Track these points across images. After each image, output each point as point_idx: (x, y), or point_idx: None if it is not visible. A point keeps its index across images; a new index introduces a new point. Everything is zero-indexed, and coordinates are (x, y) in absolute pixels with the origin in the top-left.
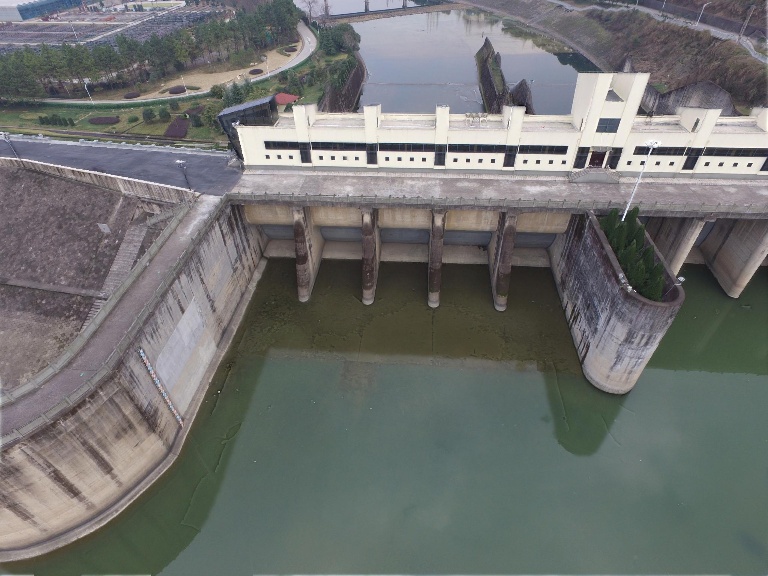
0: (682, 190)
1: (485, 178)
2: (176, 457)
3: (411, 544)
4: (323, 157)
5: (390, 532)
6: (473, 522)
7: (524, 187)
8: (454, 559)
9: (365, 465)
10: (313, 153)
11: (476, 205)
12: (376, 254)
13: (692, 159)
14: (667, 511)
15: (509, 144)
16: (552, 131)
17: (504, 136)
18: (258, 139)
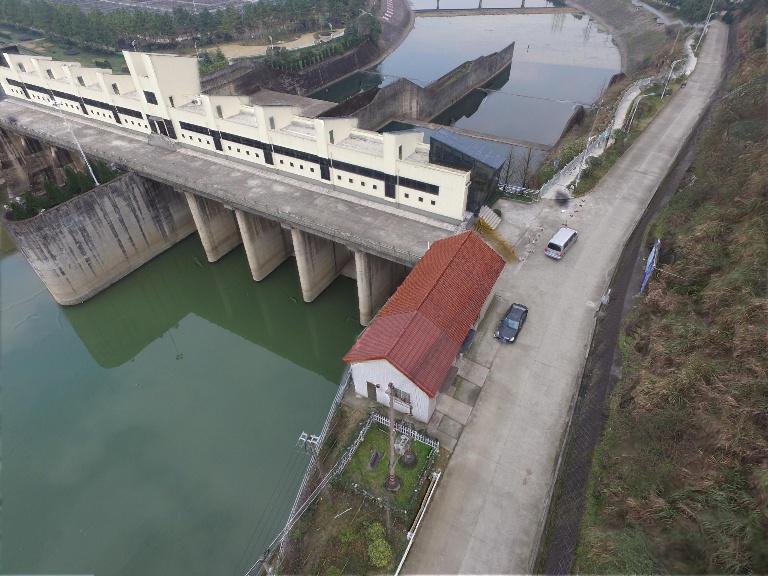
0: (201, 166)
1: (107, 130)
2: None
3: None
4: (34, 96)
5: None
6: None
7: (115, 140)
8: None
9: None
10: (29, 91)
11: (60, 143)
12: None
13: None
14: None
15: (110, 104)
16: (126, 97)
17: None
18: (3, 76)
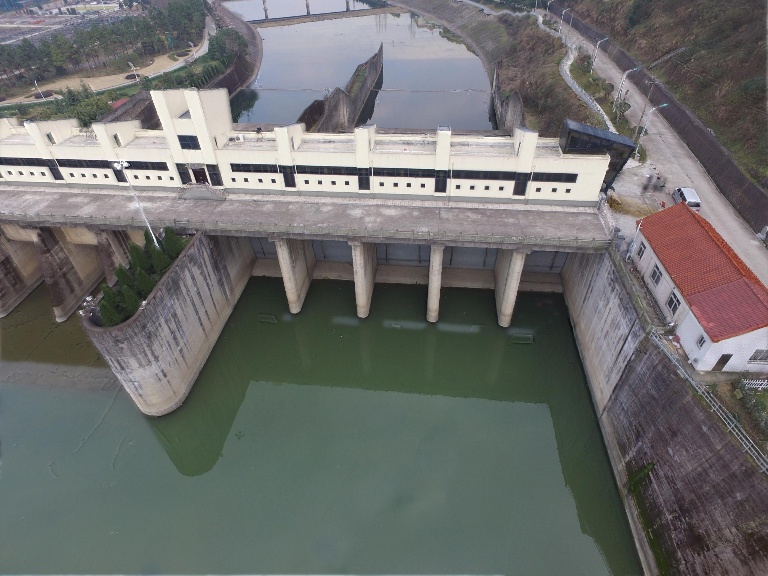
0: (277, 208)
1: (103, 193)
2: None
3: None
4: None
5: None
6: None
7: (129, 203)
8: None
9: None
10: None
11: (56, 221)
12: (18, 267)
13: (290, 177)
14: (96, 539)
15: (110, 160)
16: (143, 147)
17: (102, 152)
18: None
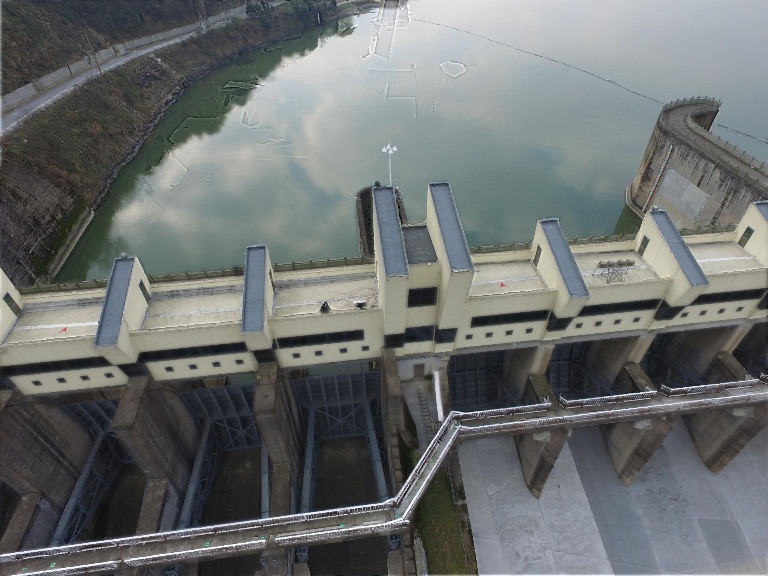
0: None
1: None
2: (628, 205)
3: (486, 203)
4: None
5: (498, 204)
6: (460, 212)
7: None
8: (465, 202)
9: (526, 221)
10: None
11: None
12: None
13: None
14: None
15: None
16: (488, 255)
17: None
18: None
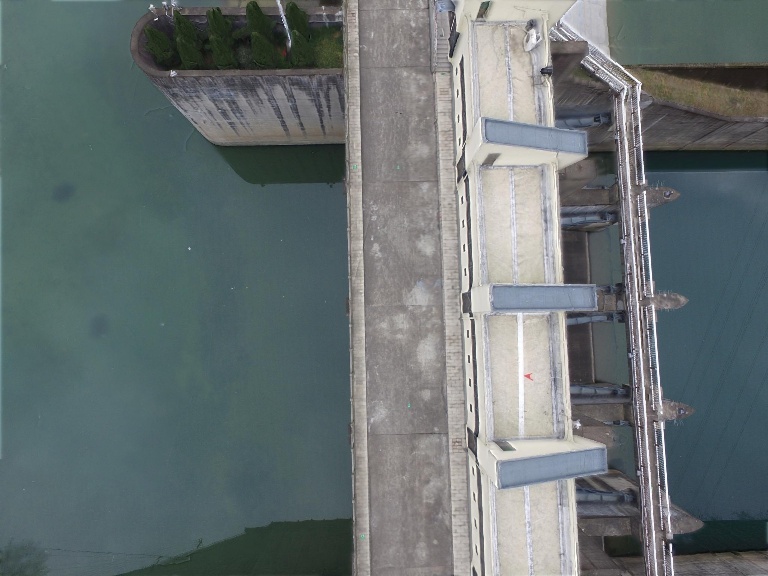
0: (417, 166)
1: None
2: None
3: None
4: None
5: None
6: None
7: None
8: None
9: None
10: None
11: None
12: None
13: None
14: None
15: None
16: None
17: None
18: None
